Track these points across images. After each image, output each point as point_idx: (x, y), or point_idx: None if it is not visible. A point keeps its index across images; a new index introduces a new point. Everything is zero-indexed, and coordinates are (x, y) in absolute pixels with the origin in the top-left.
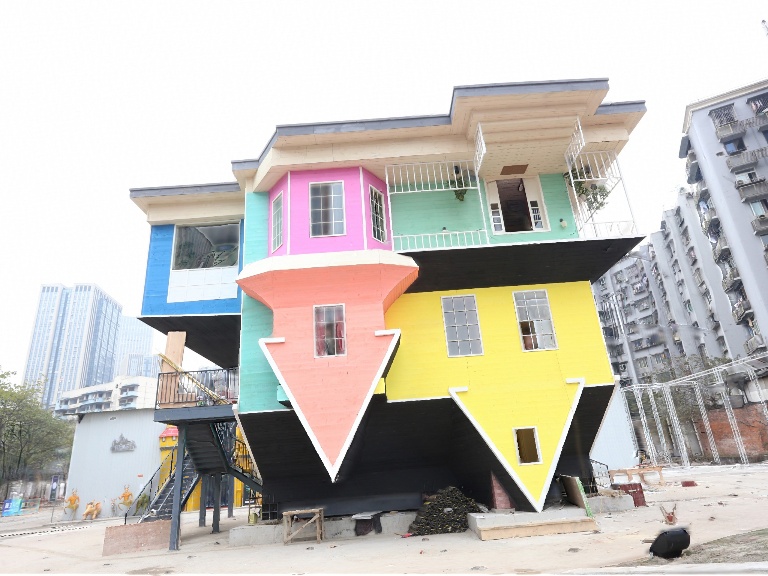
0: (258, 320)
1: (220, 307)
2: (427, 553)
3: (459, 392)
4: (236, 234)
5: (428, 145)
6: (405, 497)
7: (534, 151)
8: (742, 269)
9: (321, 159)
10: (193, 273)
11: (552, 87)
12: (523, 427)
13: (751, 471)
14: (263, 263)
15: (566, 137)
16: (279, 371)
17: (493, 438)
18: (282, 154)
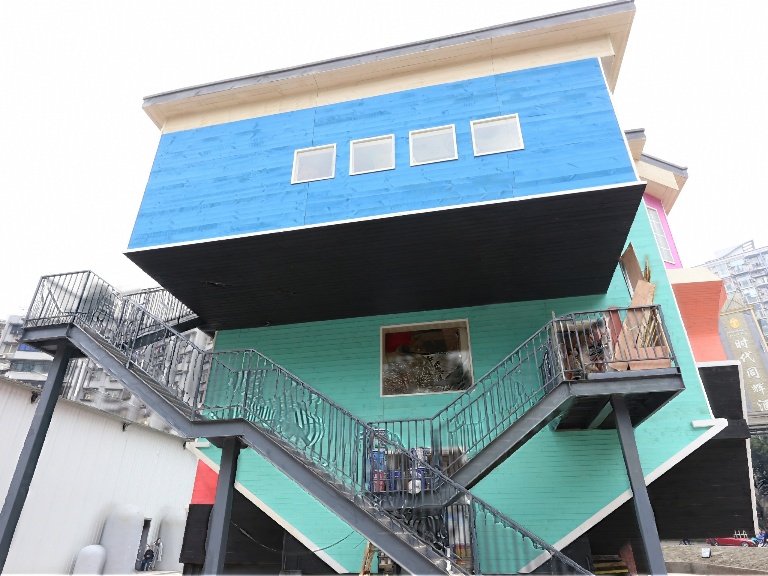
0: None
1: None
2: None
3: None
4: None
5: None
6: None
7: None
8: None
9: None
10: None
11: None
12: None
13: None
14: None
15: None
16: None
17: None
18: None
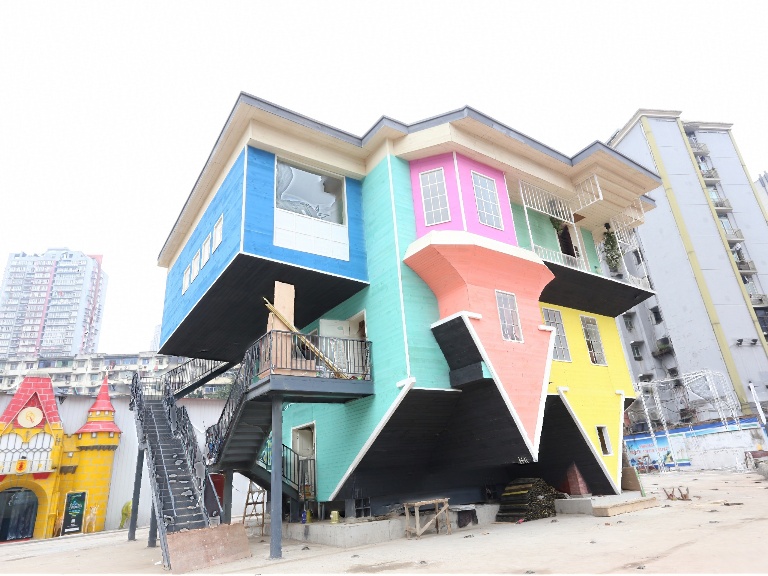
0: (416, 291)
1: (333, 267)
2: (612, 524)
3: (563, 391)
4: (307, 189)
5: (552, 176)
6: (470, 491)
7: (601, 209)
8: None
9: (487, 153)
10: (301, 219)
11: (641, 169)
12: (600, 425)
13: None
14: (457, 234)
15: (623, 207)
16: (483, 347)
17: (587, 433)
18: (458, 133)
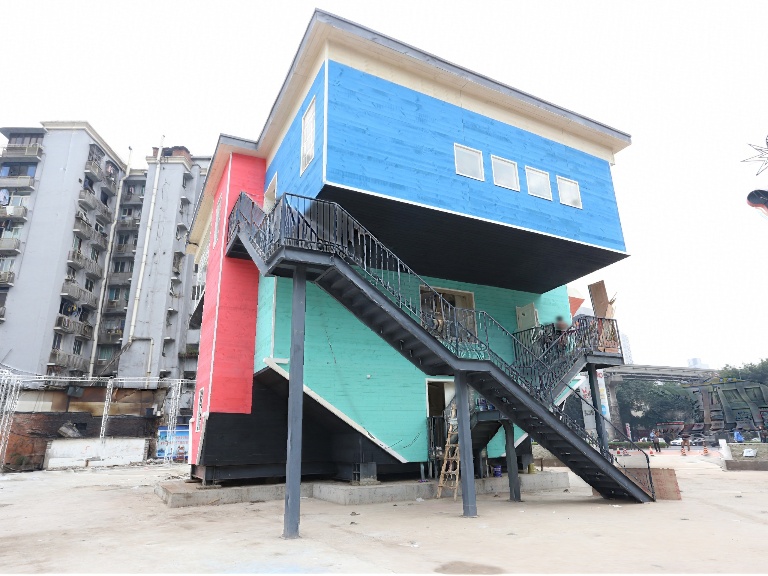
0: None
1: None
2: None
3: None
4: None
5: None
6: None
7: None
8: (31, 281)
9: None
10: None
11: None
12: None
13: (146, 470)
14: None
15: None
16: None
17: None
18: None
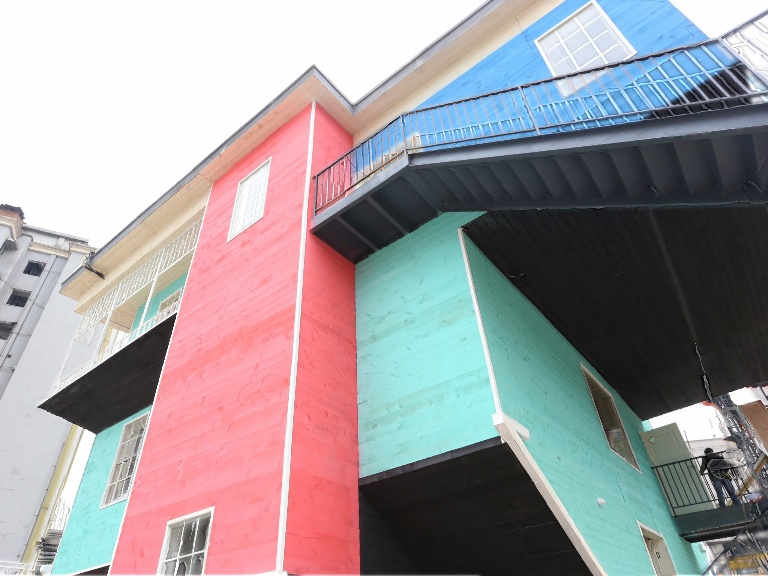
0: None
1: None
2: None
3: None
4: None
5: None
6: None
7: None
8: None
9: None
10: None
11: None
12: None
13: None
14: None
15: None
16: None
17: None
18: None
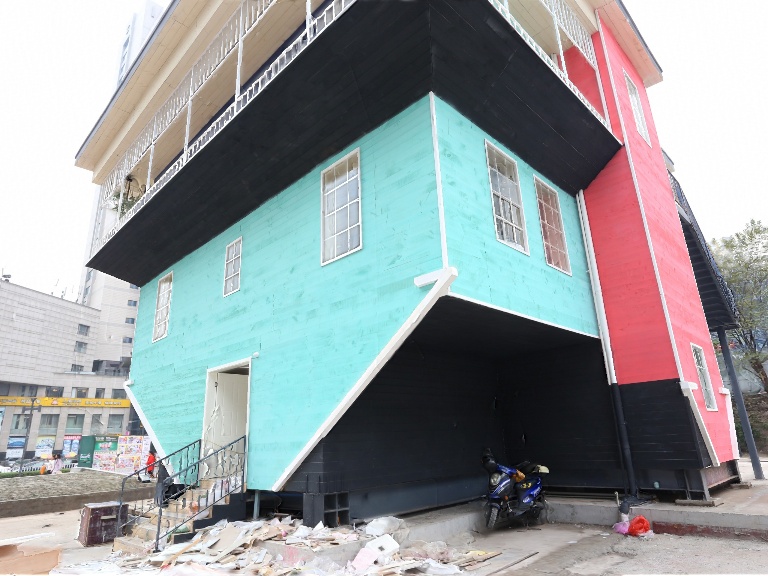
0: None
1: None
2: None
3: None
4: None
5: None
6: None
7: None
8: None
9: None
10: None
11: None
12: None
13: None
14: None
15: None
16: None
17: None
18: None
